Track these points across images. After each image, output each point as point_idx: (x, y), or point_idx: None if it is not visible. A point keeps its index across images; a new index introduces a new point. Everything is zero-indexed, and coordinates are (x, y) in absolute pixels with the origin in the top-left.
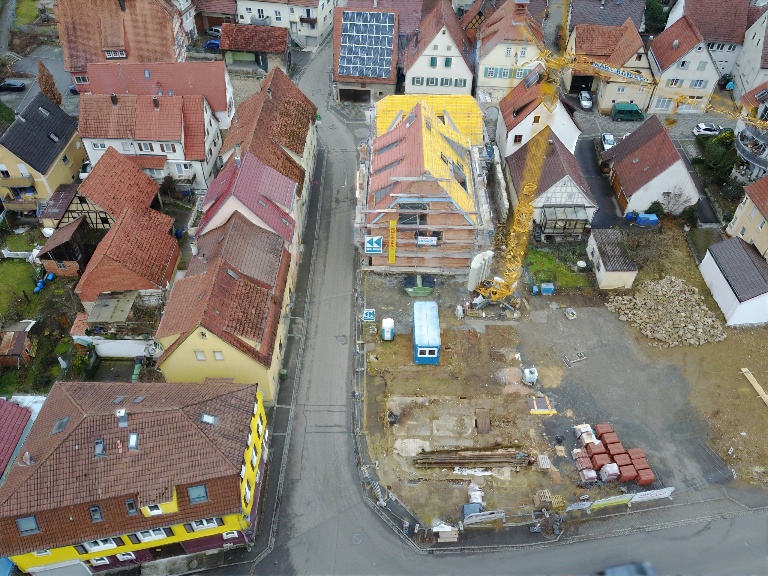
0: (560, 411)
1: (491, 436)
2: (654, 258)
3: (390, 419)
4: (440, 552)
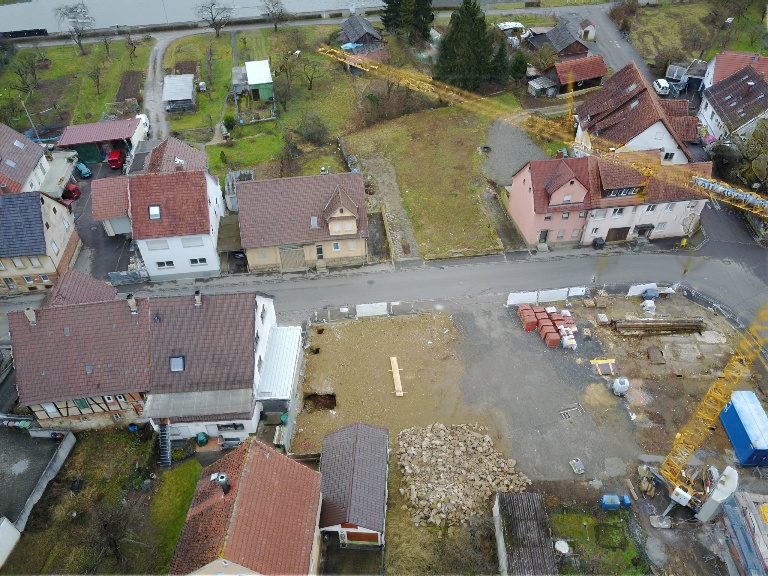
0: (588, 362)
1: (646, 344)
2: (445, 568)
3: (740, 358)
4: (665, 283)
